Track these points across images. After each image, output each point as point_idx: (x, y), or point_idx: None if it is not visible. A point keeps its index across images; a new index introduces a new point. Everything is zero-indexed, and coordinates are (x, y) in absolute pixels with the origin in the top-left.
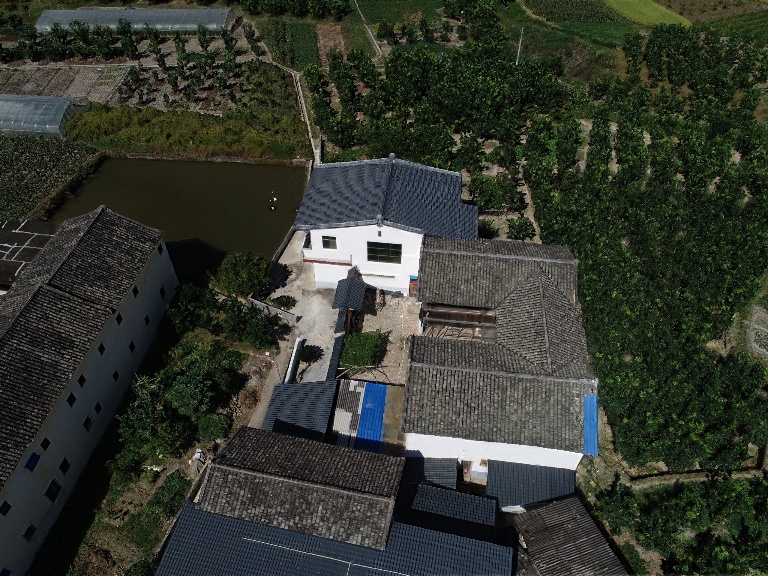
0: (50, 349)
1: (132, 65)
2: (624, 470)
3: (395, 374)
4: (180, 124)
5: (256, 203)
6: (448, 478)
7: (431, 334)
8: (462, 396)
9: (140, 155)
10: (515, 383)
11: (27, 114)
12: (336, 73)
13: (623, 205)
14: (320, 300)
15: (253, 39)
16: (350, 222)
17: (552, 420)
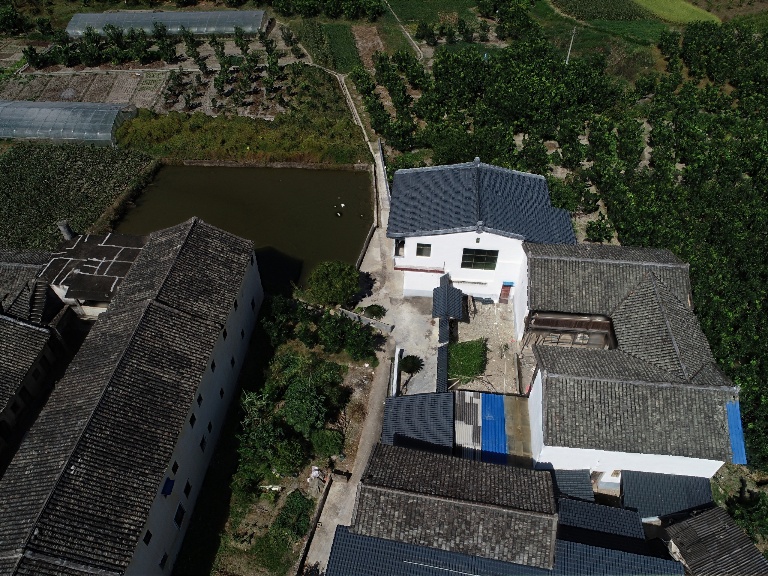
0: (169, 368)
1: (171, 69)
2: (748, 476)
3: (500, 383)
4: (233, 129)
5: (322, 209)
6: (584, 490)
7: (530, 341)
8: (603, 407)
9: (197, 162)
10: (655, 392)
11: (76, 122)
12: (386, 75)
13: (701, 205)
14: (410, 308)
15: (289, 41)
16: (448, 229)
17: (697, 429)
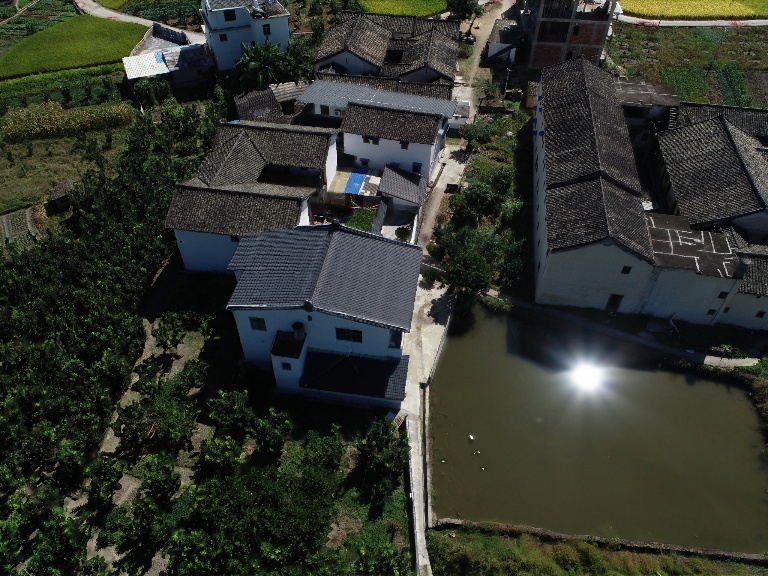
0: None
1: None
2: None
3: None
4: None
5: (501, 455)
6: None
7: None
8: None
9: (736, 553)
10: None
11: None
12: None
13: None
14: None
15: None
16: (365, 232)
17: None
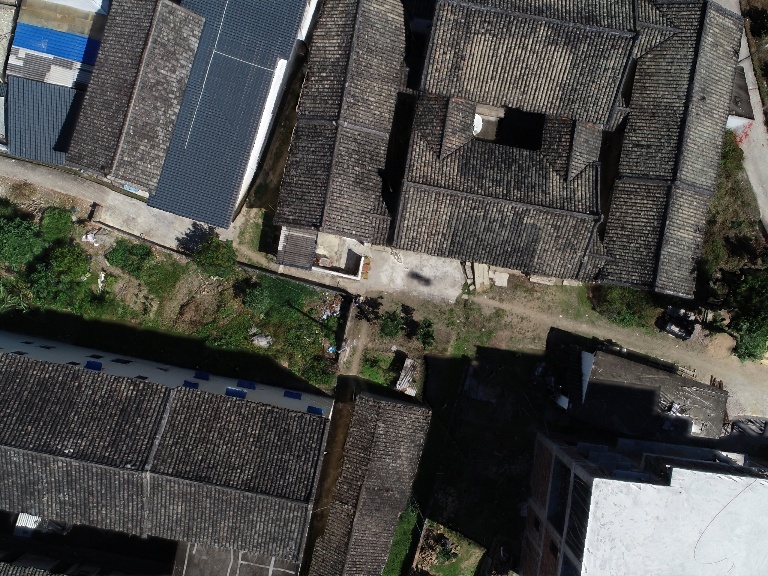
0: None
1: None
2: None
3: None
4: None
5: None
6: None
7: None
8: None
9: None
10: None
11: None
12: None
13: None
14: None
15: None
16: None
17: None
